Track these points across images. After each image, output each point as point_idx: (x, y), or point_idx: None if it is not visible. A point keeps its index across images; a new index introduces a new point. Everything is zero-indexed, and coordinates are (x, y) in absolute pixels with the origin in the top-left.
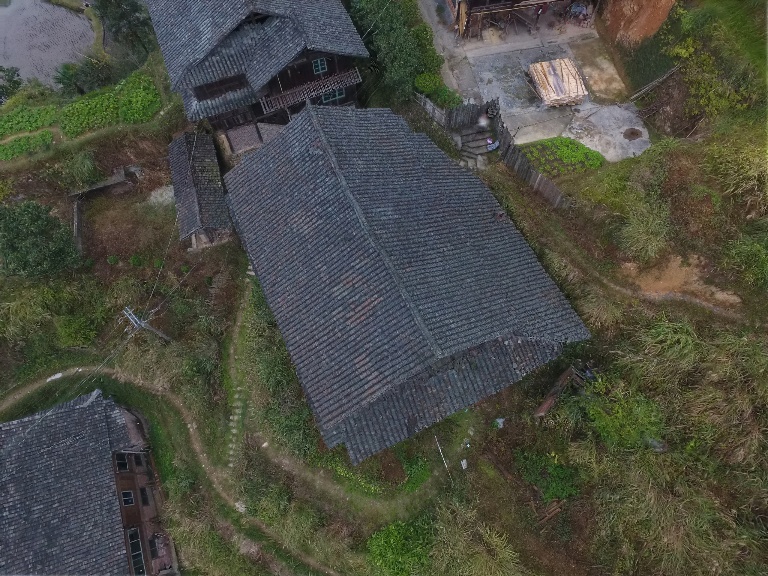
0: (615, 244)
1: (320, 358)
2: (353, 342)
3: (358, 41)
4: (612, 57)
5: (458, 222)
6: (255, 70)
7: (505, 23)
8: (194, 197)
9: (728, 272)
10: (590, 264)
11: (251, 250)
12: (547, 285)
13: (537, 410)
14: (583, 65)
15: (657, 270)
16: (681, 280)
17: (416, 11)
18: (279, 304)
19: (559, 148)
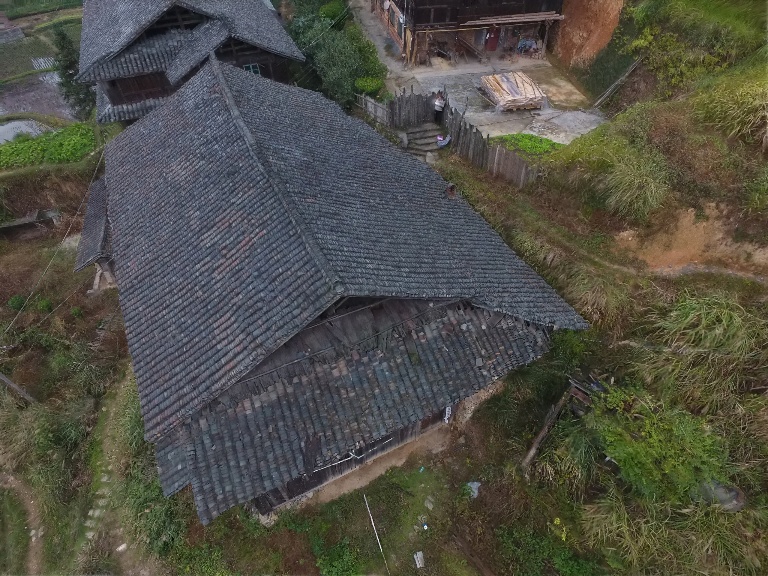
0: (602, 207)
1: (165, 331)
2: (216, 299)
3: (294, 49)
4: (568, 79)
5: (394, 185)
6: (175, 66)
7: (453, 47)
8: (102, 226)
9: (764, 212)
10: (573, 242)
11: (111, 212)
12: (519, 266)
13: (525, 455)
14: (539, 83)
15: (664, 234)
16: (700, 244)
17: (361, 38)
18: (127, 269)
19: (520, 140)
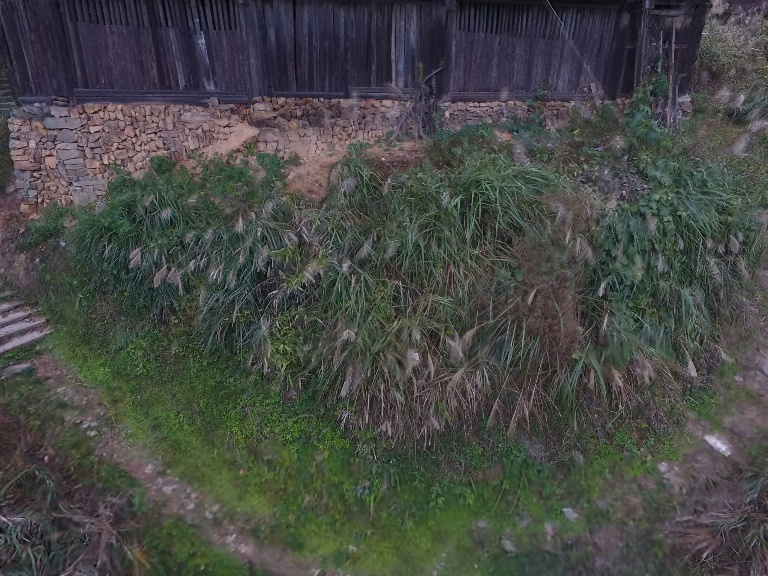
0: None
1: None
2: None
3: None
4: None
5: None
6: None
7: None
8: None
9: None
10: None
11: None
12: None
13: None
14: None
15: None
16: None
17: None
18: None
19: None
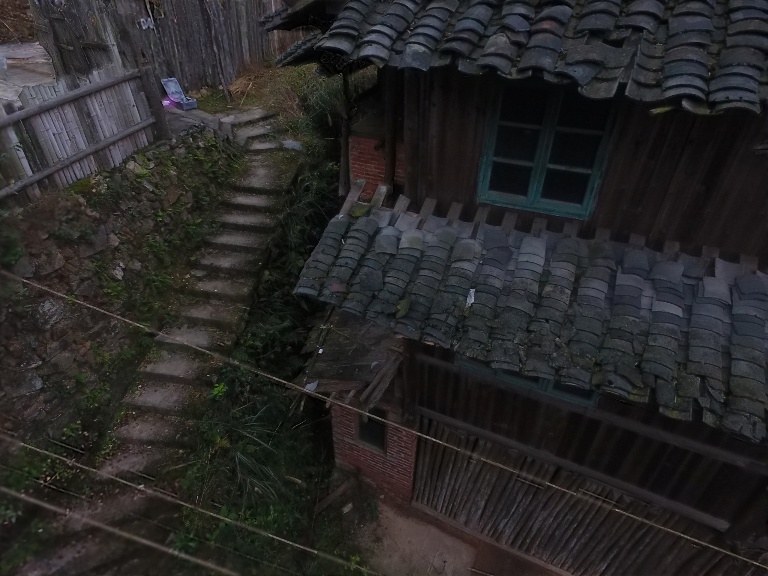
0: None
1: None
2: None
3: None
4: None
5: None
6: None
7: None
8: None
9: None
10: None
11: None
12: None
13: None
14: None
15: None
16: None
17: None
18: None
19: None
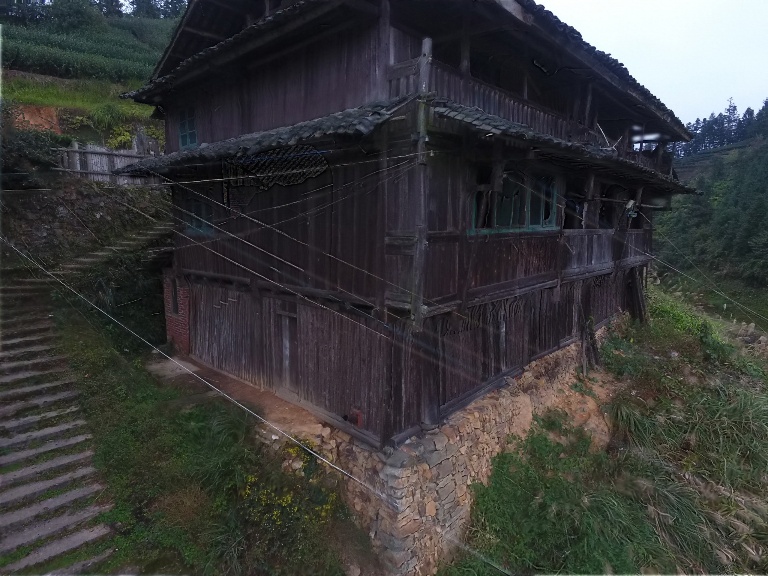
0: None
1: None
2: None
3: None
4: None
5: None
6: None
7: None
8: None
9: None
10: None
11: None
12: None
13: None
14: None
15: None
16: None
17: None
18: None
19: None
